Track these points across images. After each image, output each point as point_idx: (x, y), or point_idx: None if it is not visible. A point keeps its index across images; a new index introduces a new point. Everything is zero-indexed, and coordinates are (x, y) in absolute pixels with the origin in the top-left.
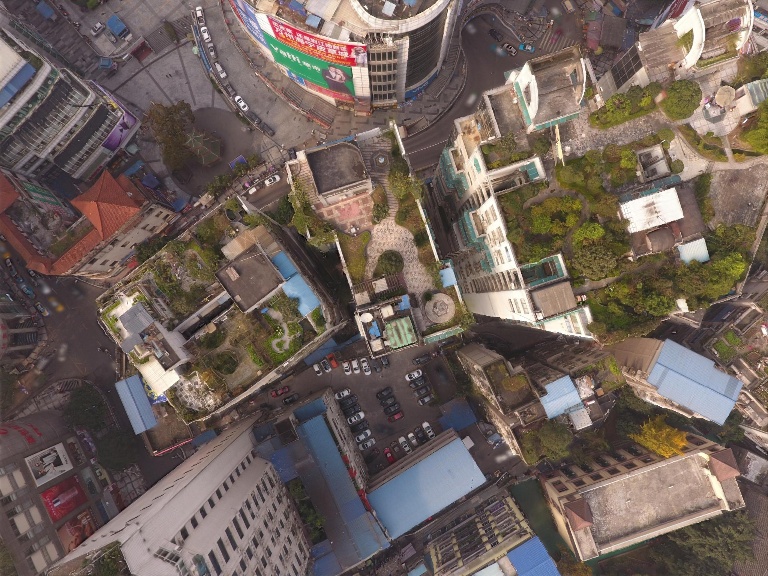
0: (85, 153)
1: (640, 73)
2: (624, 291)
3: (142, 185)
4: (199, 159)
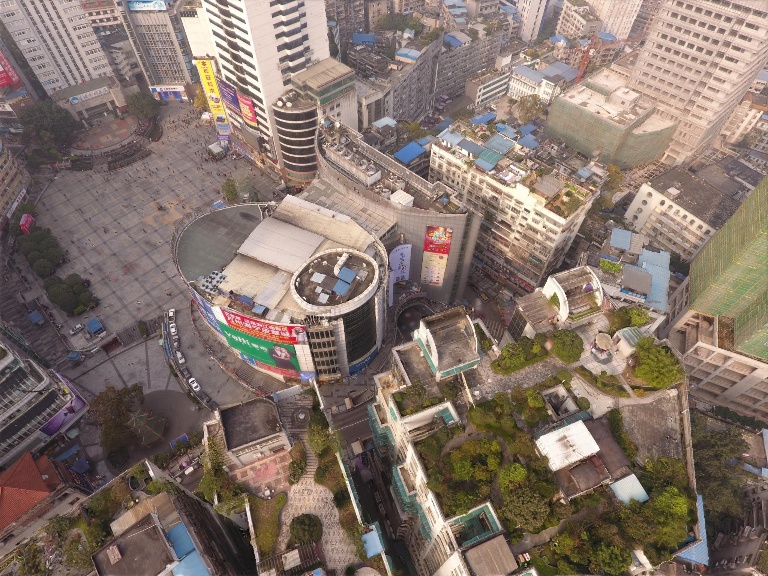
0: (18, 438)
1: (527, 328)
2: (567, 543)
3: (64, 467)
4: (139, 439)
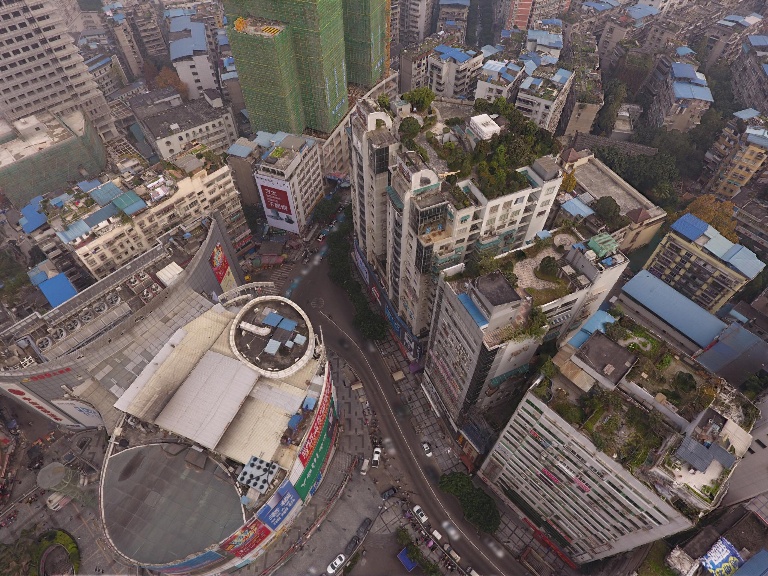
0: None
1: (391, 149)
2: None
3: None
4: None
